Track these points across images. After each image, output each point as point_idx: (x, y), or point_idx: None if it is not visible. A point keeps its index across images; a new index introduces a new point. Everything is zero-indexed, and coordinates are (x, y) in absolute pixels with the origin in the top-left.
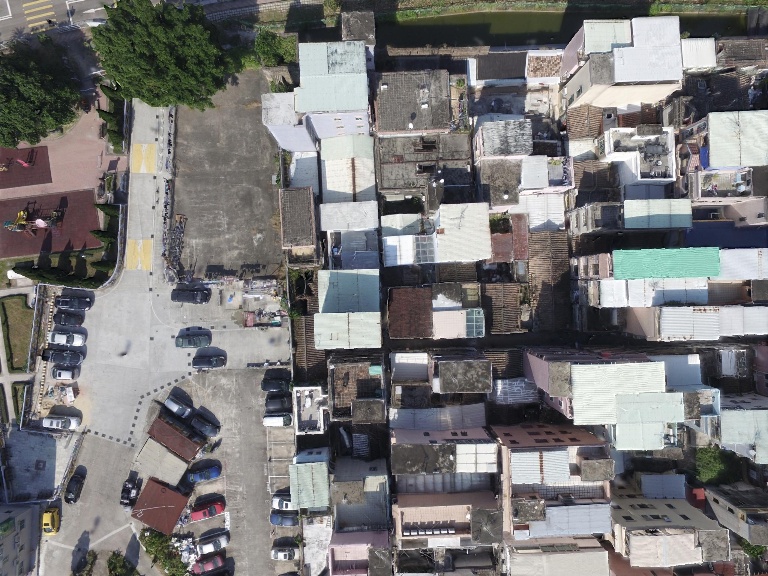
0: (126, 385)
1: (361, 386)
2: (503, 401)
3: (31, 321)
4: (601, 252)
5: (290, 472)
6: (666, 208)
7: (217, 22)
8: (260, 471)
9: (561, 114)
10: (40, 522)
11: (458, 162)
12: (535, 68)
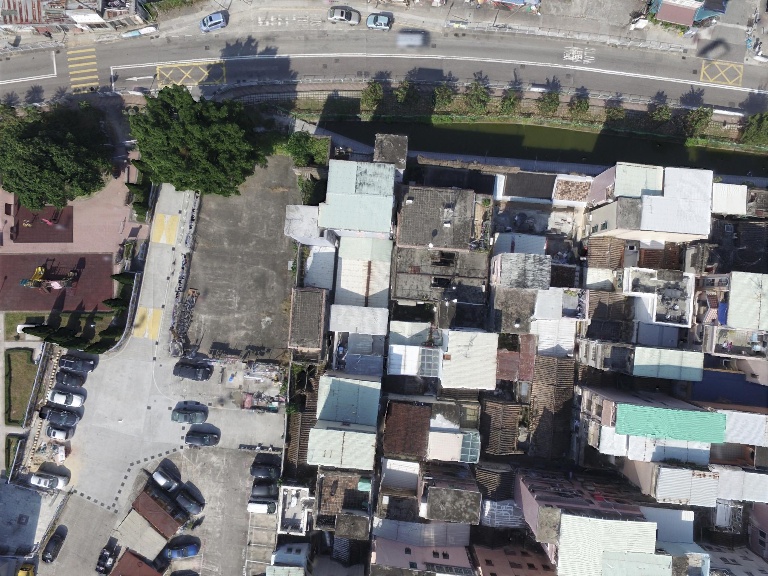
0: (118, 450)
1: (348, 496)
2: (489, 523)
3: (34, 376)
4: (607, 385)
5: (267, 574)
6: (677, 359)
7: (254, 104)
8: (238, 554)
9: (583, 237)
10: None
11: (474, 280)
12: (563, 191)
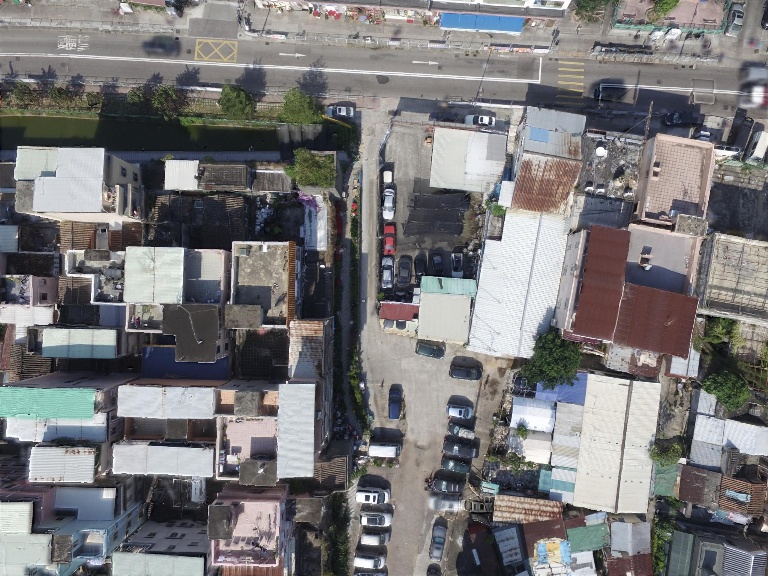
0: None
1: None
2: None
3: None
4: (78, 369)
5: None
6: (89, 338)
7: None
8: None
9: None
10: None
11: None
12: None
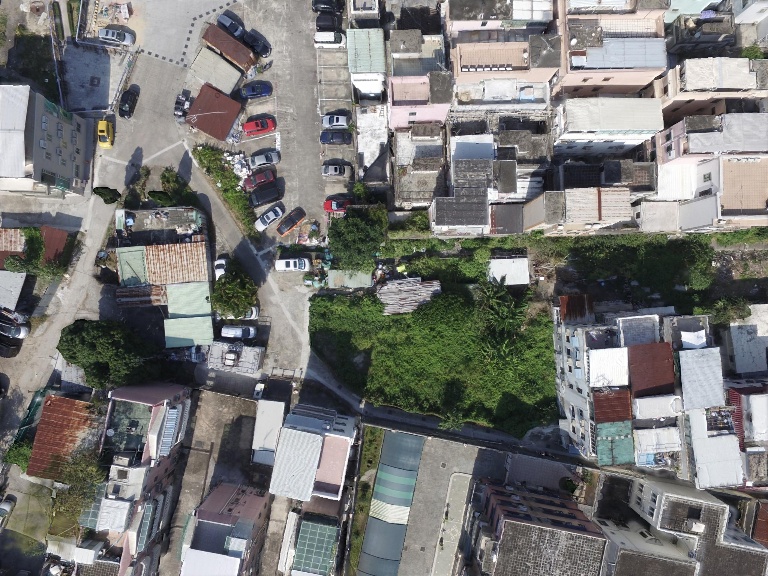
0: (179, 7)
1: None
2: None
3: None
4: None
5: (347, 36)
6: None
7: None
8: (310, 93)
9: None
10: (94, 136)
11: None
12: None
